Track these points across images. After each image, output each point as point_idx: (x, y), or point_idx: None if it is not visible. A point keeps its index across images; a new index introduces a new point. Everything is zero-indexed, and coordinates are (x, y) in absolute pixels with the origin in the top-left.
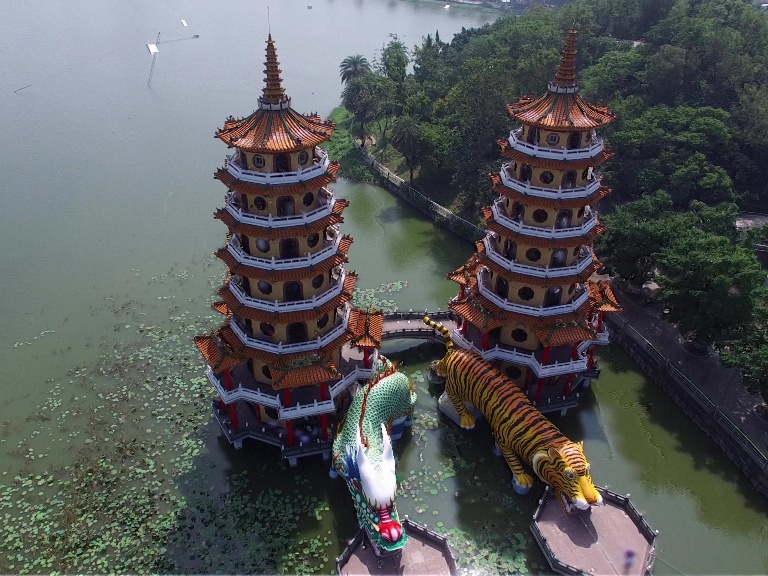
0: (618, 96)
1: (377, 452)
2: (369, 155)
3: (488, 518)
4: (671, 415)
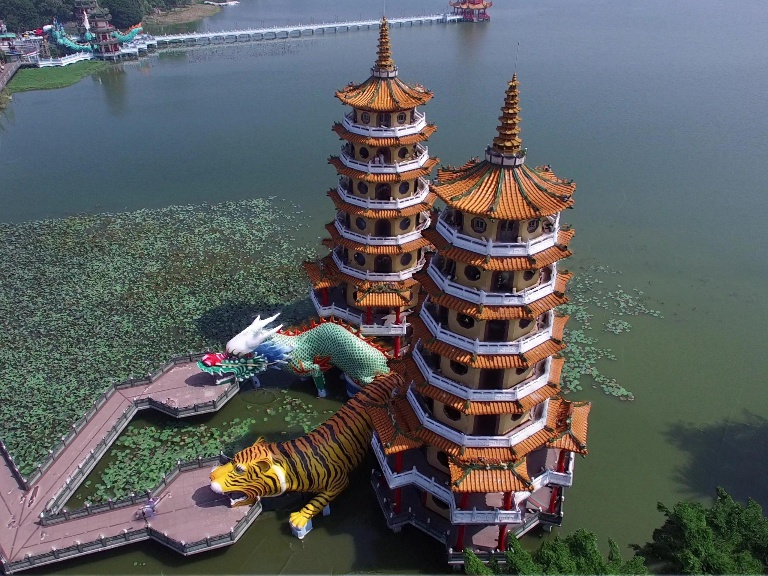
0: None
1: None
2: None
3: None
4: None
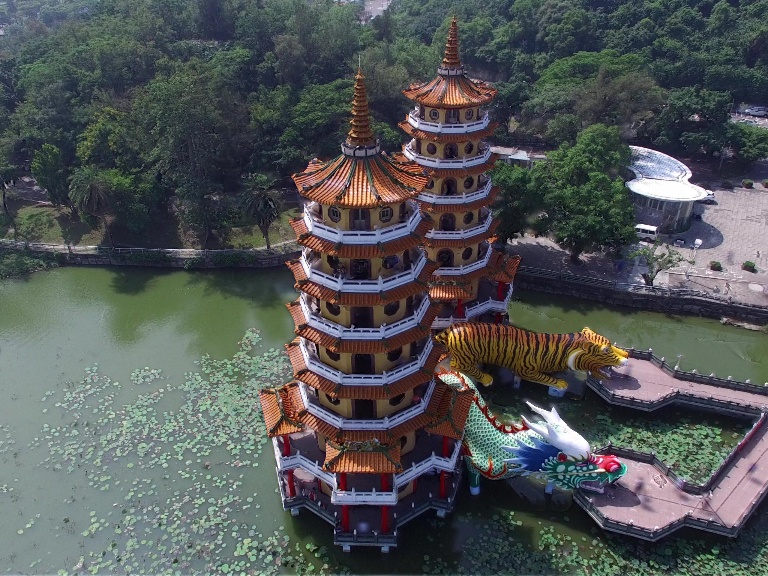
0: (264, 89)
1: (543, 425)
2: (1, 241)
3: (576, 424)
4: (532, 297)
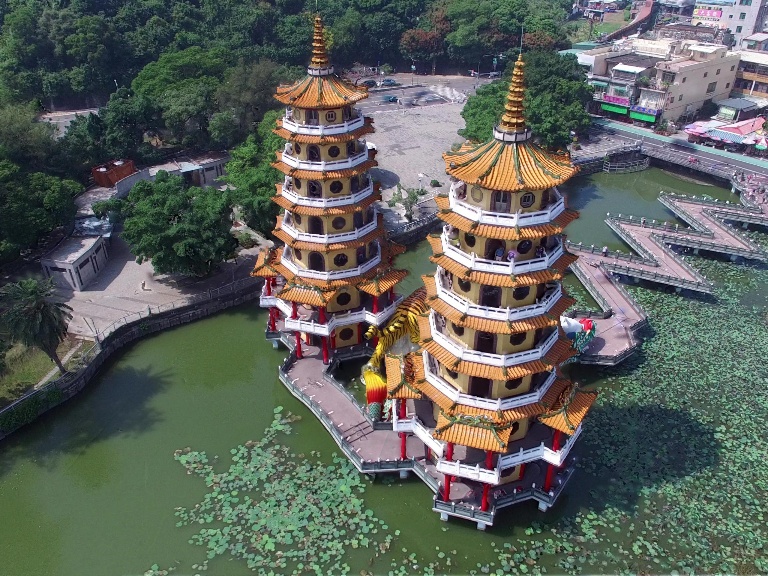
0: None
1: None
2: None
3: None
4: None
